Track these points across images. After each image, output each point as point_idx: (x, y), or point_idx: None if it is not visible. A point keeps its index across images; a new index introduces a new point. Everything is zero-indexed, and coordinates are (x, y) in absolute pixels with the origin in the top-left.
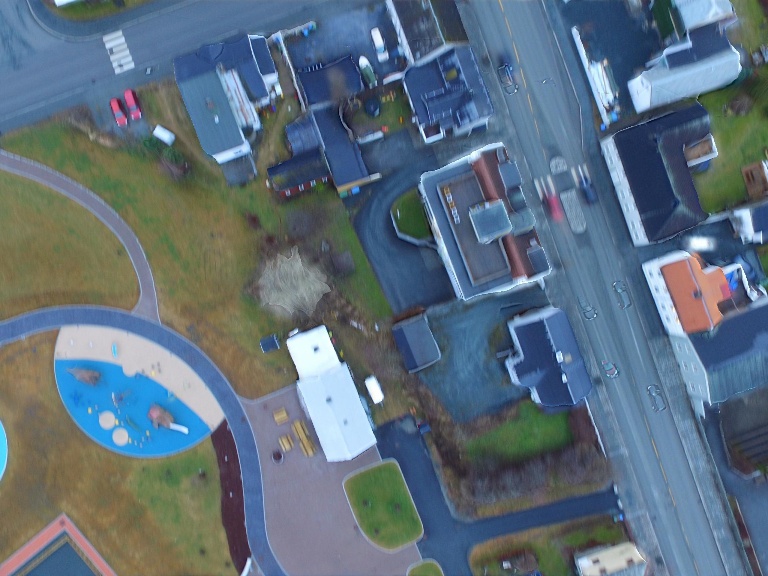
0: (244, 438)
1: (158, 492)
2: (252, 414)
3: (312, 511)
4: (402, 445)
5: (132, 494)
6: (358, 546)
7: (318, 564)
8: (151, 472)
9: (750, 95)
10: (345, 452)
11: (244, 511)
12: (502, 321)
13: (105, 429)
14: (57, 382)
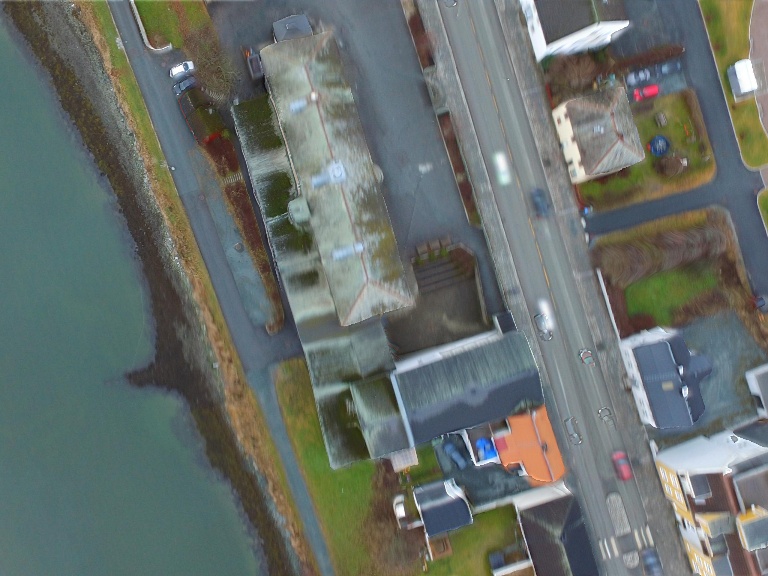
0: None
1: None
2: None
3: None
4: None
5: None
6: None
7: None
8: None
9: None
10: None
11: None
12: None
13: None
14: None
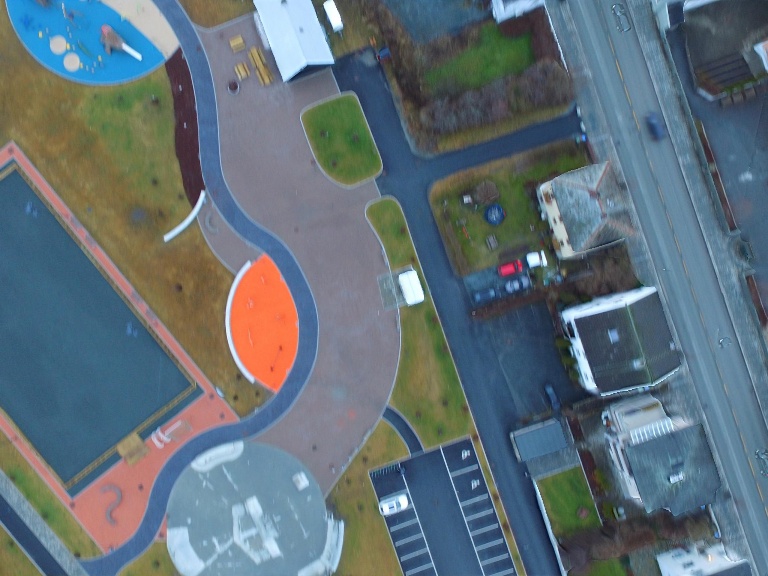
0: (199, 67)
1: (110, 118)
2: (208, 43)
3: (268, 144)
4: (362, 78)
5: (83, 121)
6: (315, 181)
7: (274, 199)
8: (103, 99)
9: None
10: (300, 58)
11: (198, 143)
12: None
13: (56, 54)
14: (7, 5)
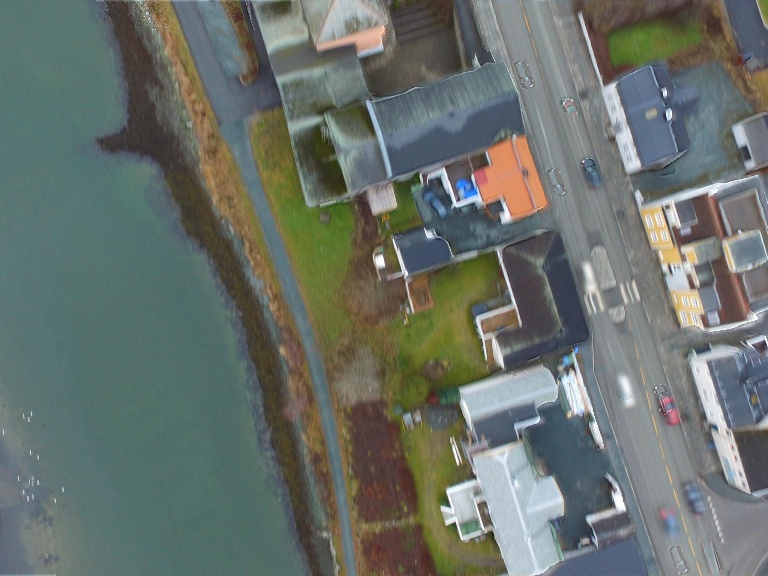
0: None
1: None
2: None
3: None
4: (759, 43)
5: None
6: None
7: None
8: None
9: (429, 379)
10: None
11: None
12: (676, 160)
13: None
14: None
